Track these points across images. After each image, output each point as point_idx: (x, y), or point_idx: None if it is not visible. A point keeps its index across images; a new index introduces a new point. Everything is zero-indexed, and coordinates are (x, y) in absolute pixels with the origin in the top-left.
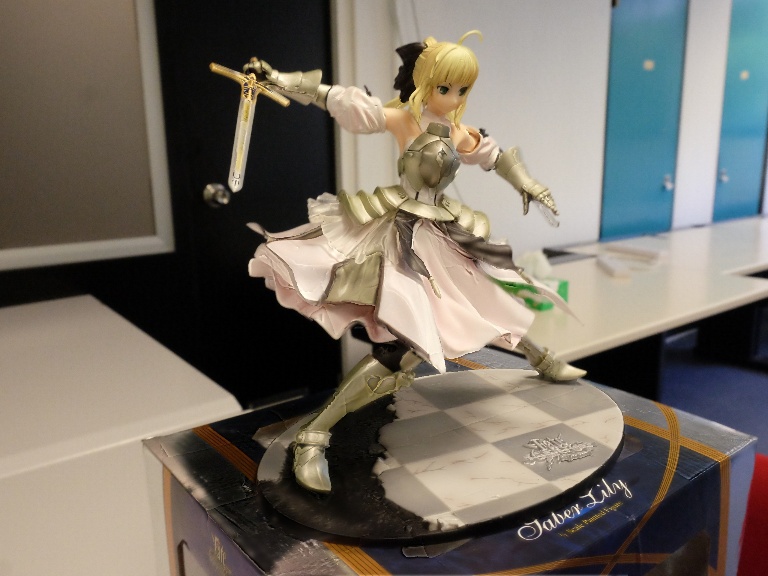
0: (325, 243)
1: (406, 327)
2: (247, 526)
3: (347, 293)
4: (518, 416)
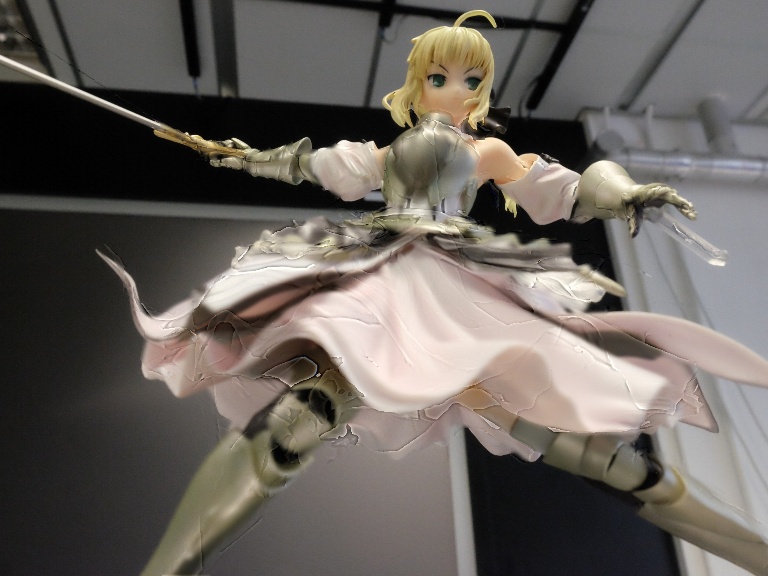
0: None
1: None
2: None
3: None
4: None
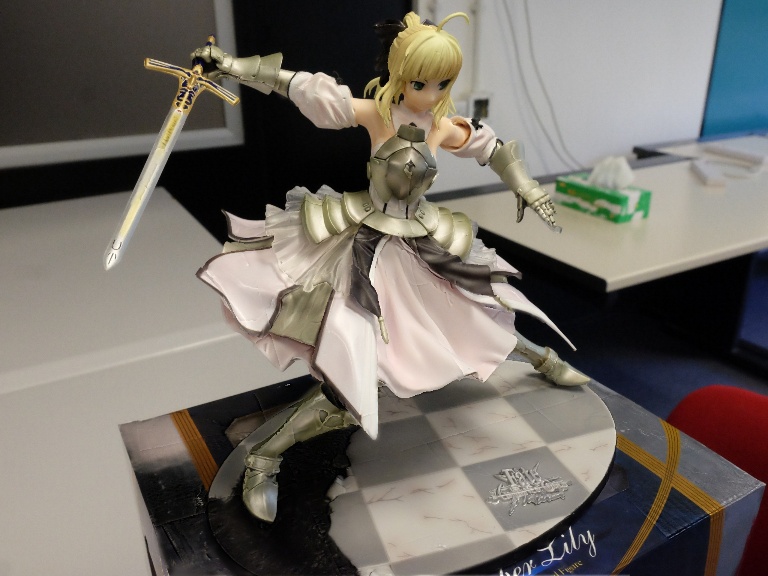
0: (277, 262)
1: (342, 379)
2: (185, 553)
3: (292, 325)
4: (501, 431)
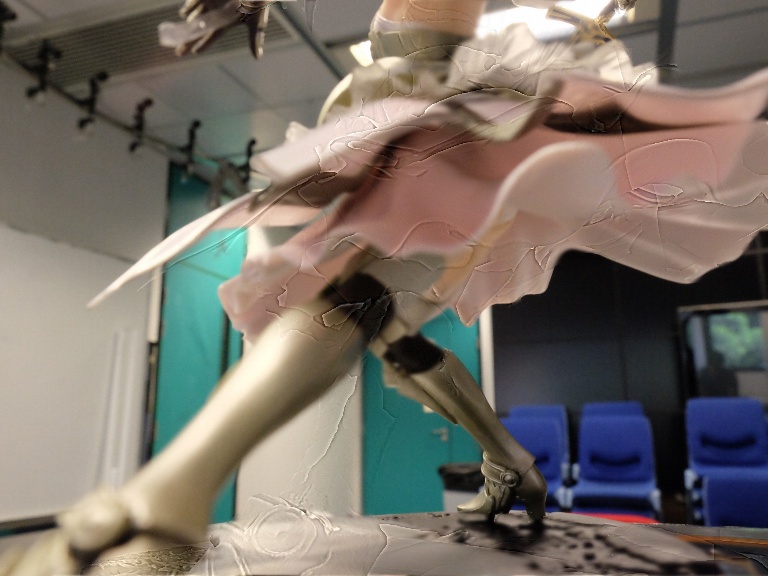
0: None
1: None
2: None
3: None
4: None
